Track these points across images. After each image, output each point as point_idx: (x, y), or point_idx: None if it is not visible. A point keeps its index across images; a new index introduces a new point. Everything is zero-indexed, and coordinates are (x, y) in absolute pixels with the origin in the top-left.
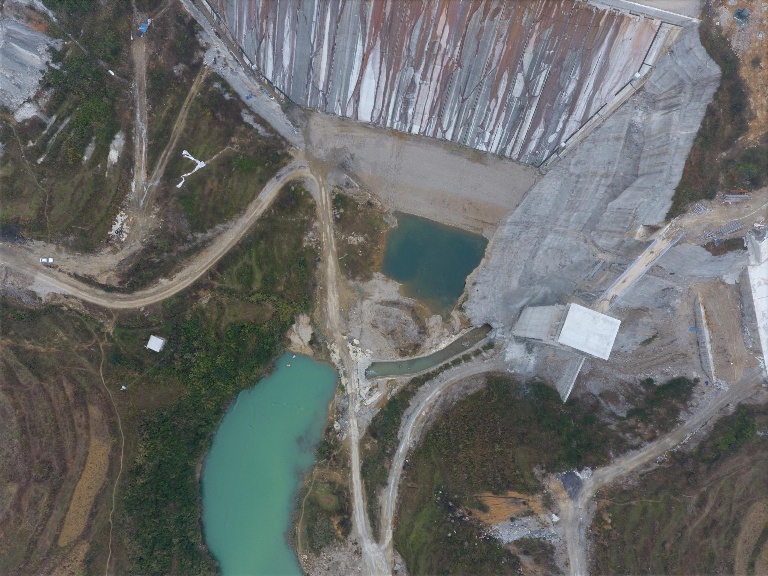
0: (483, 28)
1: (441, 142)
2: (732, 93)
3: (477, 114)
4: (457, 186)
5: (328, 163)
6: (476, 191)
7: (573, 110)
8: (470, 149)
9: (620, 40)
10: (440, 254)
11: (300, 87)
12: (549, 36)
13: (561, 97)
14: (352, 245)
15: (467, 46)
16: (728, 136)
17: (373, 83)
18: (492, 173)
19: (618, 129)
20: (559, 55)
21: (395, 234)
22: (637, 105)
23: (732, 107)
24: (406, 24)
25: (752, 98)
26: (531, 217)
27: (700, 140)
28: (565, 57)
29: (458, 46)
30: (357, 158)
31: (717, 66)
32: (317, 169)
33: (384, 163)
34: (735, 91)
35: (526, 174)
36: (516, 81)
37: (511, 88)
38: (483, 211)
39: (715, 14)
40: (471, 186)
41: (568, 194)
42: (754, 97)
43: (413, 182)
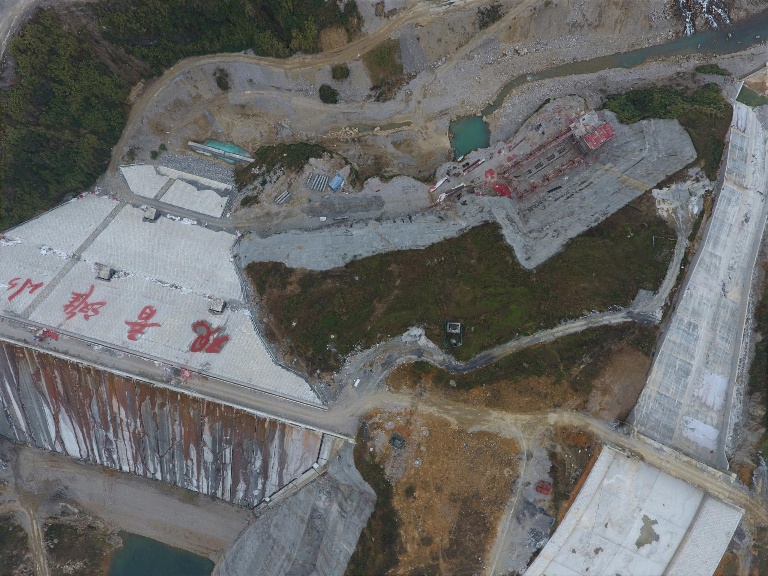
0: (156, 413)
1: (152, 481)
2: (383, 523)
3: (178, 467)
4: (174, 519)
5: (40, 496)
6: (193, 525)
7: (267, 477)
8: (182, 489)
9: (289, 439)
10: (167, 574)
11: (5, 427)
12: (221, 427)
13: (252, 468)
14: (67, 574)
15: (147, 423)
16: (379, 566)
17: (71, 434)
18: (204, 514)
19: (304, 509)
20: (236, 440)
21: (121, 553)
22: (321, 489)
23: (383, 537)
24: (82, 401)
25: (403, 531)
26: (233, 572)
27: (351, 567)
28: (243, 443)
29: (138, 422)
30: (72, 489)
31: (373, 490)
32: (28, 502)
33: (99, 495)
34: (386, 522)
35: (239, 516)
36: (204, 451)
37: (202, 455)
38: (205, 540)
39: (370, 438)
40: (187, 521)
41: (263, 559)
42: (405, 529)
43: (131, 511)
